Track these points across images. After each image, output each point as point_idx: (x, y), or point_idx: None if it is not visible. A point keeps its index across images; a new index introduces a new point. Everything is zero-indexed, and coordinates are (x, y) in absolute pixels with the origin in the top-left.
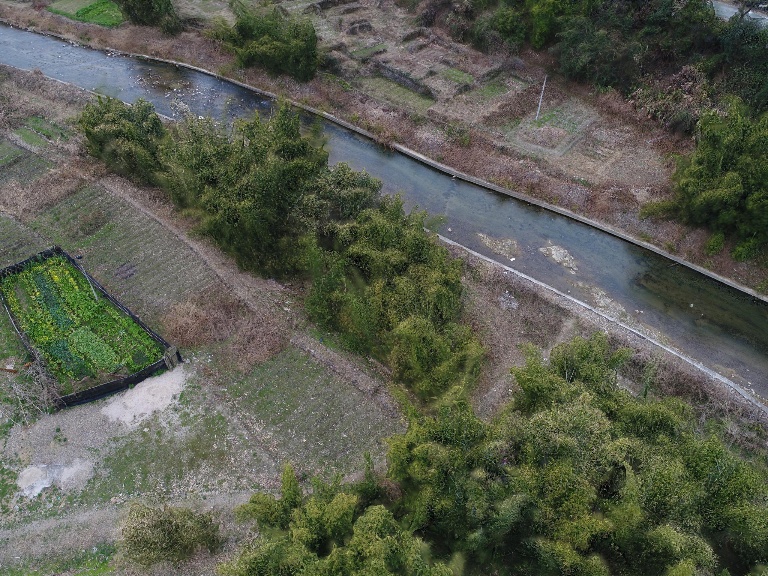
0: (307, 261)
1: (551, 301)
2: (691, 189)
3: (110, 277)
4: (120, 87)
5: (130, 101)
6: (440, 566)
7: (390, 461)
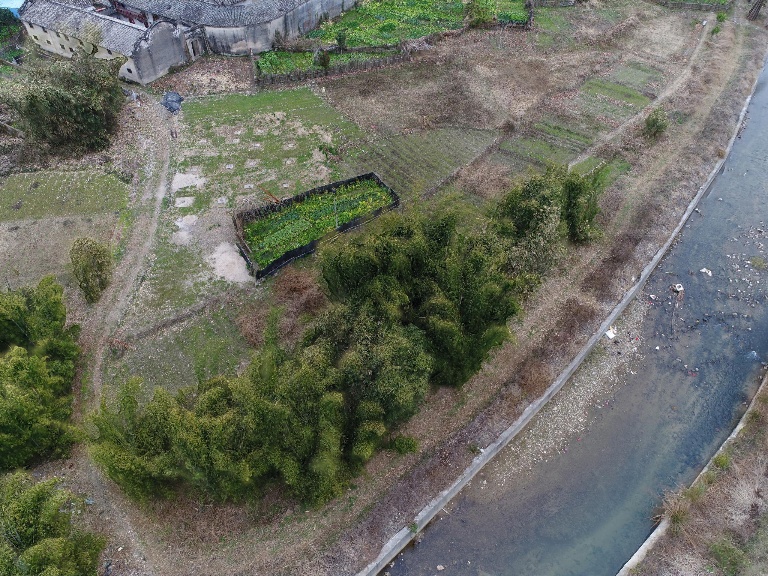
0: None
1: None
2: None
3: None
4: (735, 217)
5: (705, 228)
6: None
7: None
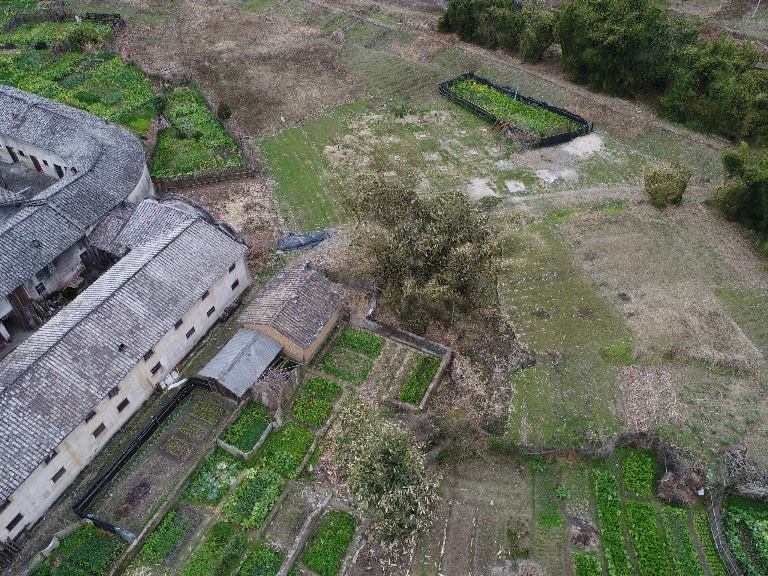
0: (662, 75)
1: None
2: None
3: None
4: None
5: None
6: None
7: None
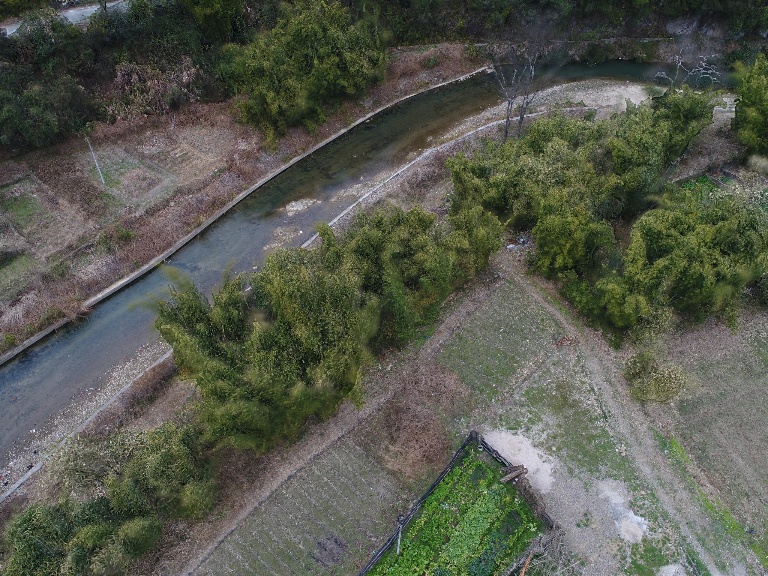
0: None
1: (370, 206)
2: (285, 106)
3: (341, 568)
4: None
5: None
6: (650, 212)
7: (563, 262)
